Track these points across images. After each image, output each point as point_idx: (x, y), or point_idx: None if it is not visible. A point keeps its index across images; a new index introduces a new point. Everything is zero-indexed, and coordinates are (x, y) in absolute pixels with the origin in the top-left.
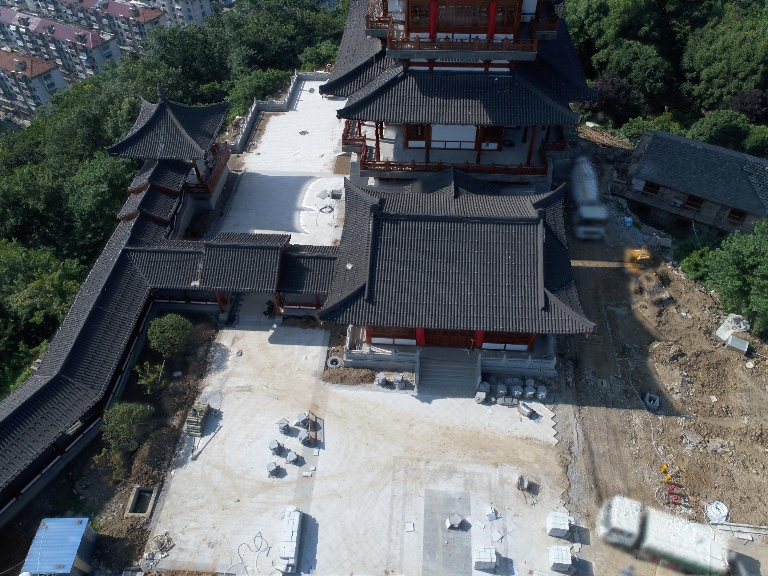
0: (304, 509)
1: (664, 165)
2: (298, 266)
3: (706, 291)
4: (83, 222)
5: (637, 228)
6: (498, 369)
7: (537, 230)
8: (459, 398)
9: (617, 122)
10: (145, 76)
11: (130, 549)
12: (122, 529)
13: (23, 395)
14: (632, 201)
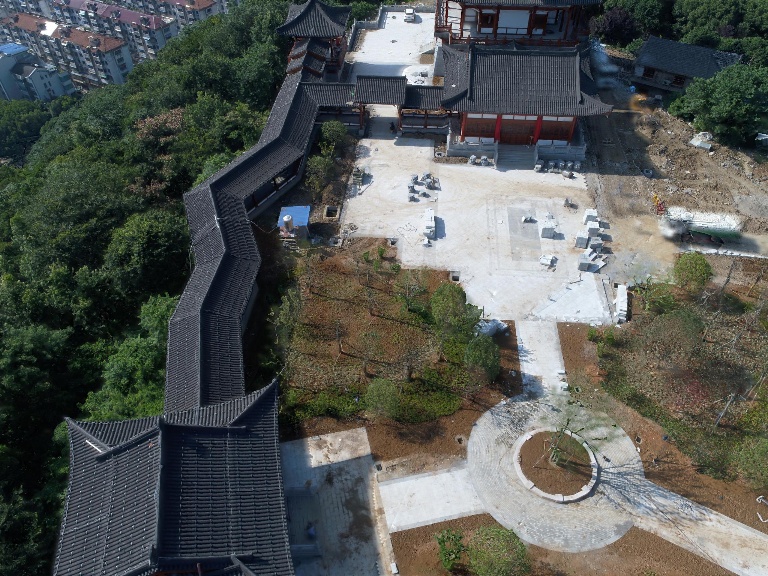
0: (434, 214)
1: (658, 56)
2: (416, 93)
3: (685, 123)
4: (245, 90)
5: (638, 94)
6: (548, 155)
7: (575, 60)
8: (524, 170)
9: (623, 45)
10: (273, 2)
11: (332, 228)
12: (325, 220)
13: (256, 150)
14: (635, 83)
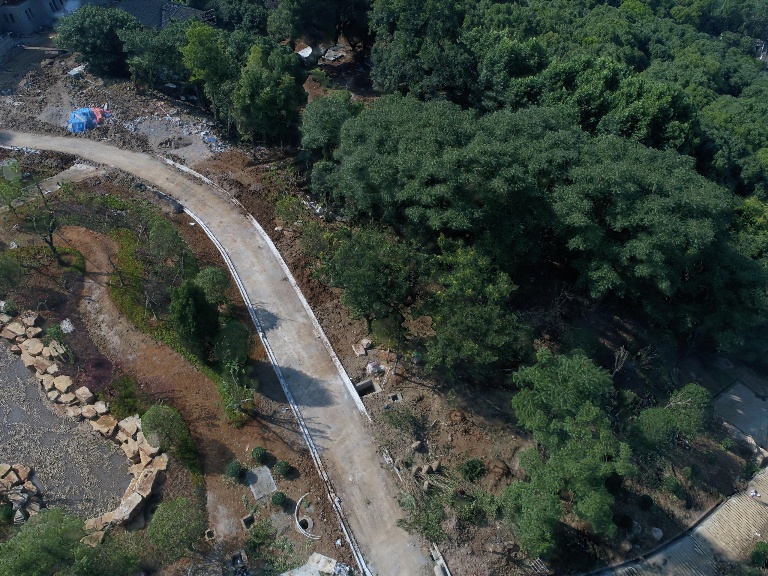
0: None
1: (127, 8)
2: None
3: None
4: None
5: None
6: None
7: None
8: None
9: None
10: None
11: None
12: None
13: None
14: None
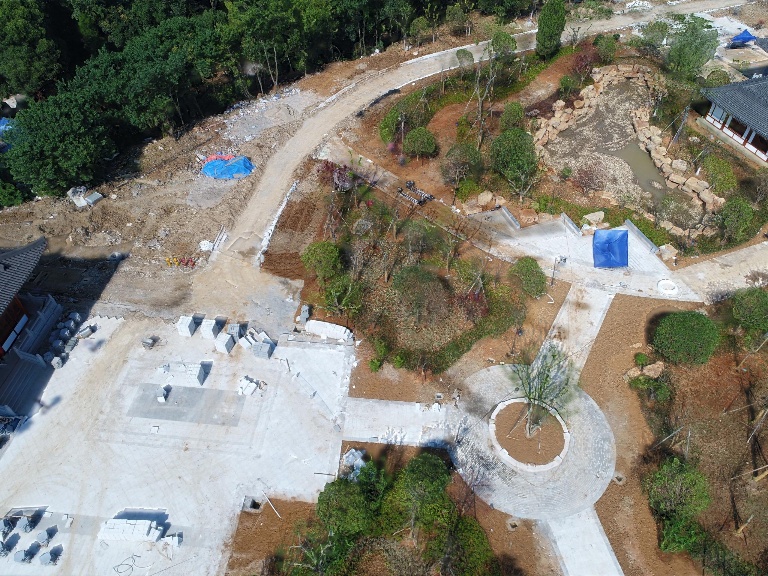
0: None
1: None
2: None
3: None
4: None
5: None
6: (35, 344)
7: None
8: (49, 381)
9: None
10: None
11: None
12: None
13: None
14: None
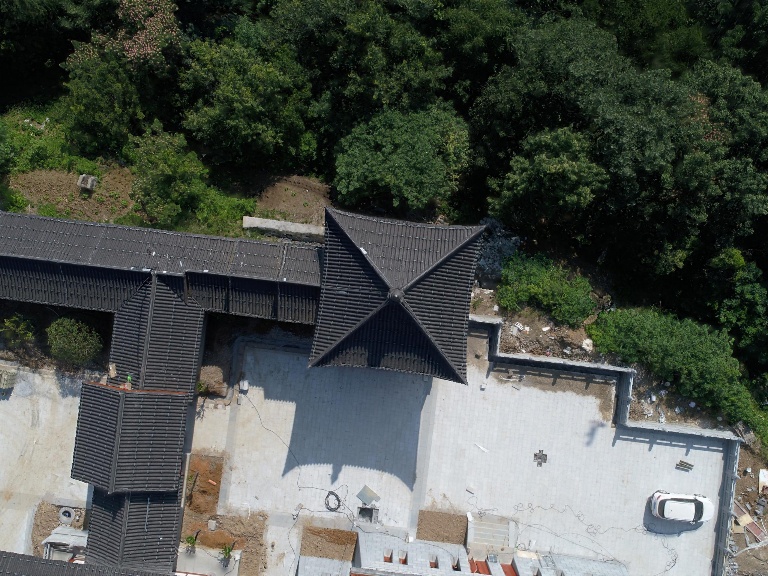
0: None
1: None
2: (119, 503)
3: None
4: None
5: None
6: None
7: None
8: None
9: None
10: None
11: None
12: None
13: None
14: None
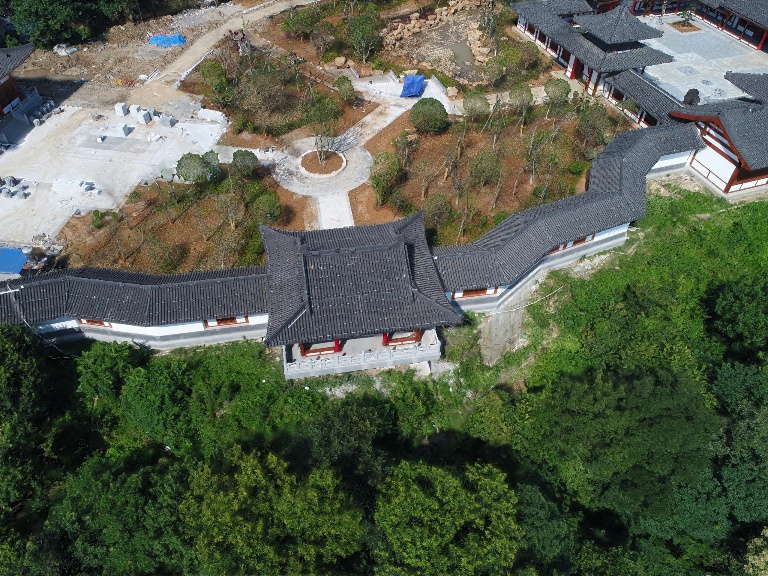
0: None
1: None
2: None
3: None
4: None
5: None
6: None
7: None
8: (31, 131)
9: None
10: None
11: None
12: None
13: None
14: None
